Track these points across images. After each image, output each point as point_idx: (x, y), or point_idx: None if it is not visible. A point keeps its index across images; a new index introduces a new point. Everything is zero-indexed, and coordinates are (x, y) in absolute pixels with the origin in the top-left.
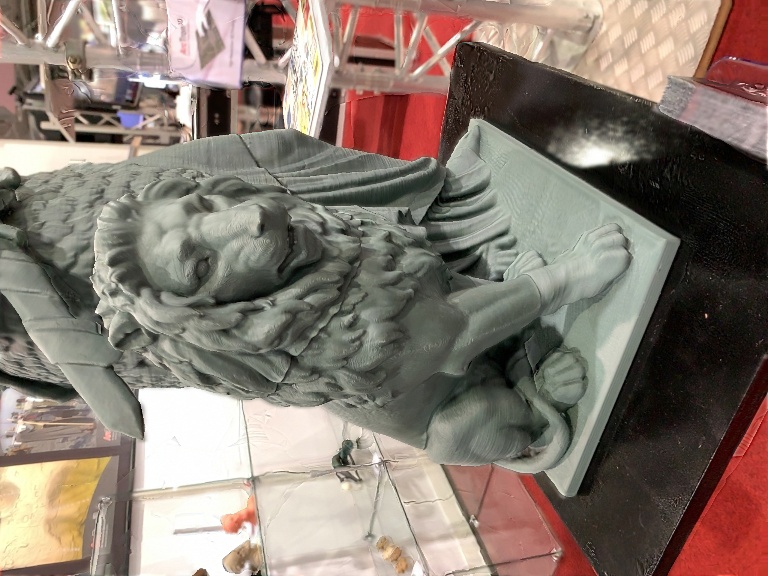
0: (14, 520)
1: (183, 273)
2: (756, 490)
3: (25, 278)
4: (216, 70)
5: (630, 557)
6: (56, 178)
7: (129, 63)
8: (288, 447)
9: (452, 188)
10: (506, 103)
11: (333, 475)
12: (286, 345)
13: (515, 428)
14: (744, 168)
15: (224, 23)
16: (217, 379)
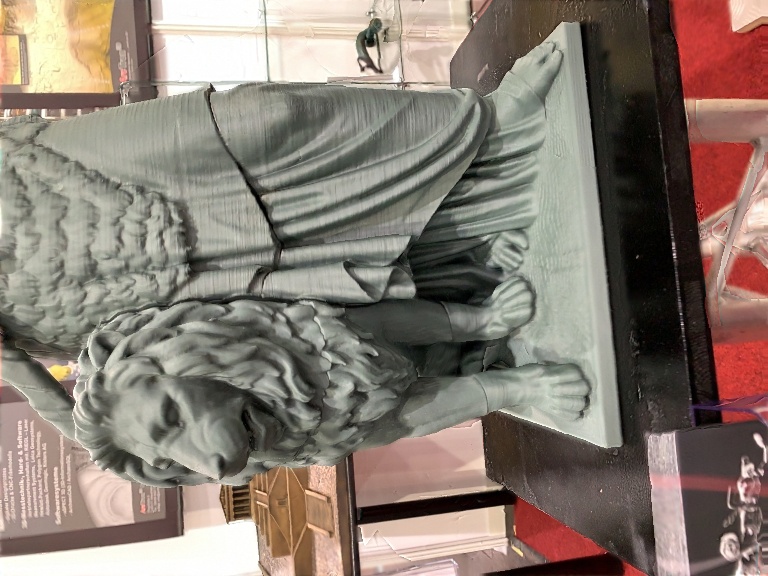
0: (39, 38)
1: None
2: None
3: (18, 375)
4: None
5: (501, 467)
6: (4, 222)
7: None
8: None
9: (489, 148)
10: (608, 61)
11: None
12: None
13: None
14: None
15: None
16: None
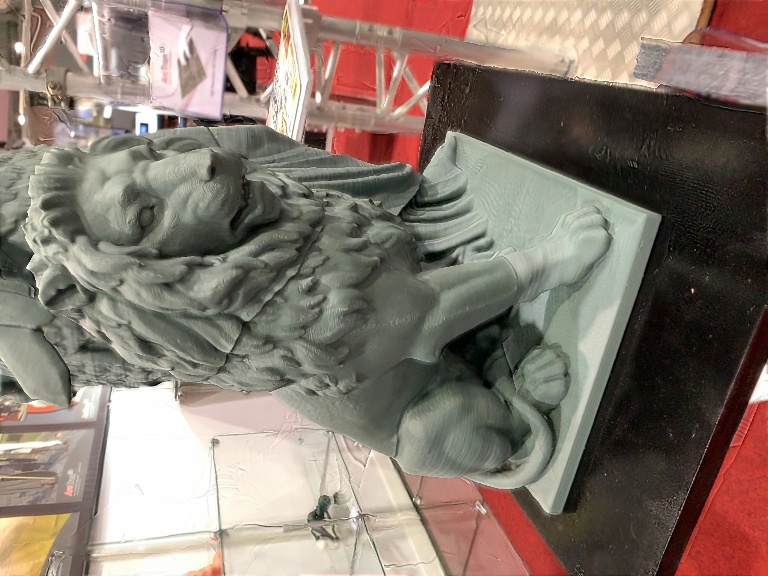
0: None
1: (124, 220)
2: (755, 531)
3: None
4: (197, 100)
5: (623, 575)
6: (6, 152)
7: (110, 92)
8: (262, 505)
9: (428, 194)
10: (482, 112)
11: (309, 535)
12: (237, 308)
13: (493, 430)
14: (723, 128)
15: (206, 52)
16: (160, 349)
